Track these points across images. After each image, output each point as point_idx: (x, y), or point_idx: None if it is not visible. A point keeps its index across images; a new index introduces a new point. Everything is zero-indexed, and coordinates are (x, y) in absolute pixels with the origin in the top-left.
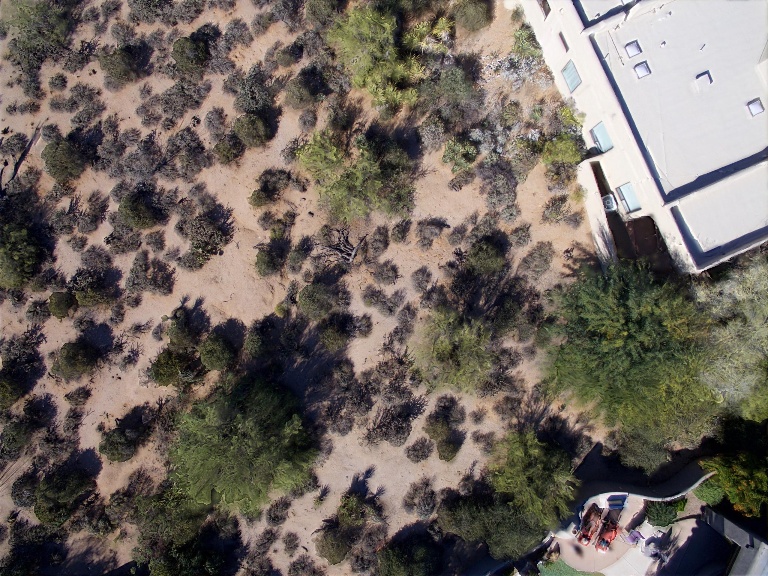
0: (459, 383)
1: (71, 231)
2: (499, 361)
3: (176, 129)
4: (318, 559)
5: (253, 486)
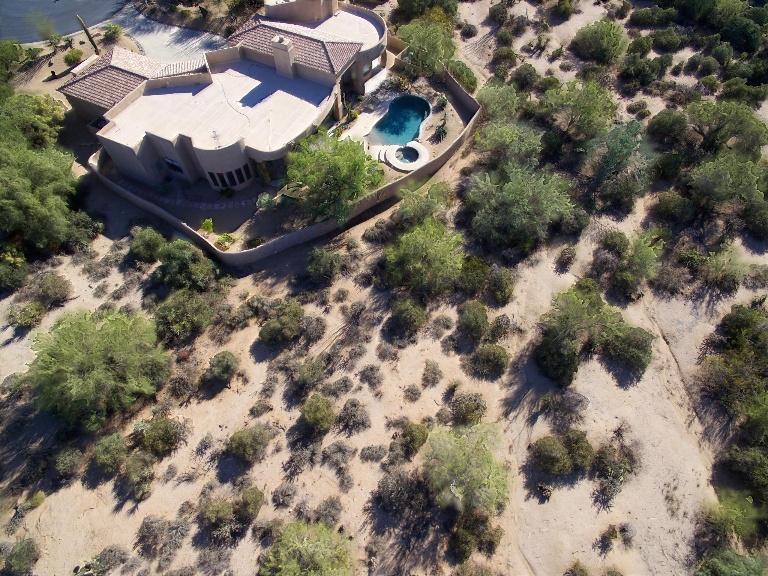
0: None
1: None
2: None
3: None
4: (83, 280)
5: None
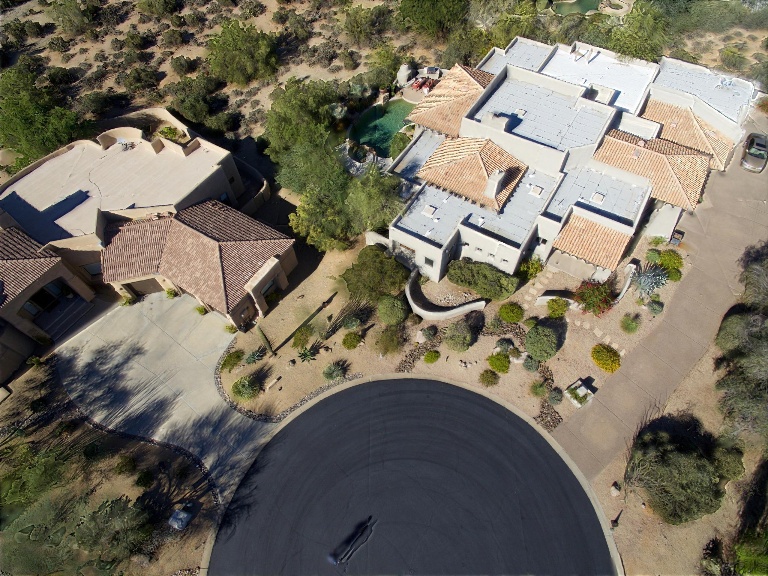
0: (361, 47)
1: (192, 5)
2: (381, 38)
3: None
4: None
5: (244, 72)
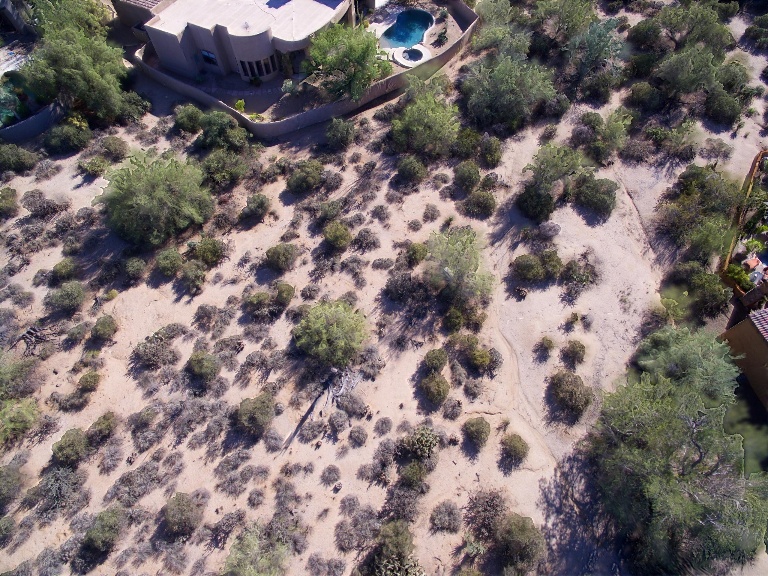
0: None
1: None
2: None
3: (154, 451)
4: (137, 144)
5: None
